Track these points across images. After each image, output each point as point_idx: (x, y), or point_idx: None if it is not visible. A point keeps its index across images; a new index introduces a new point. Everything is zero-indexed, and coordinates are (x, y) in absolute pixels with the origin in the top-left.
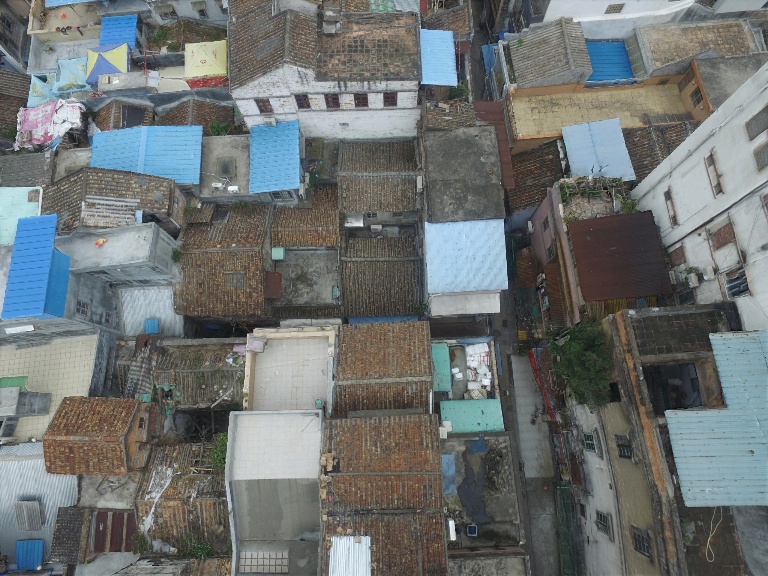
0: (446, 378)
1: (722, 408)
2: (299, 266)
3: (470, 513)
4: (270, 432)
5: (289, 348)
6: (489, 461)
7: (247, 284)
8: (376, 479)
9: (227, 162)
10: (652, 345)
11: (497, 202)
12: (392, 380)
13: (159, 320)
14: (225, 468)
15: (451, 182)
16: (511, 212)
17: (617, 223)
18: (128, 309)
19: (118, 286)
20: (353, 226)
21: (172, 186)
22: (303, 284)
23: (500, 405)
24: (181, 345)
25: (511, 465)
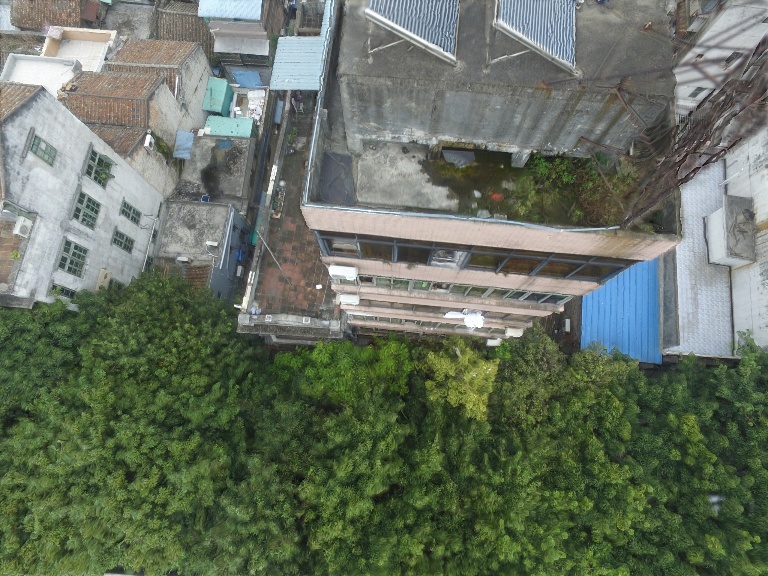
0: (219, 102)
1: (316, 36)
2: (127, 15)
3: (206, 187)
4: (38, 72)
5: (85, 47)
6: (230, 155)
7: (68, 5)
8: (100, 100)
9: None
10: None
11: None
12: (149, 65)
13: None
14: None
15: None
16: None
17: None
18: None
19: None
20: None
21: None
22: (126, 28)
23: (252, 122)
24: (2, 33)
25: (246, 159)
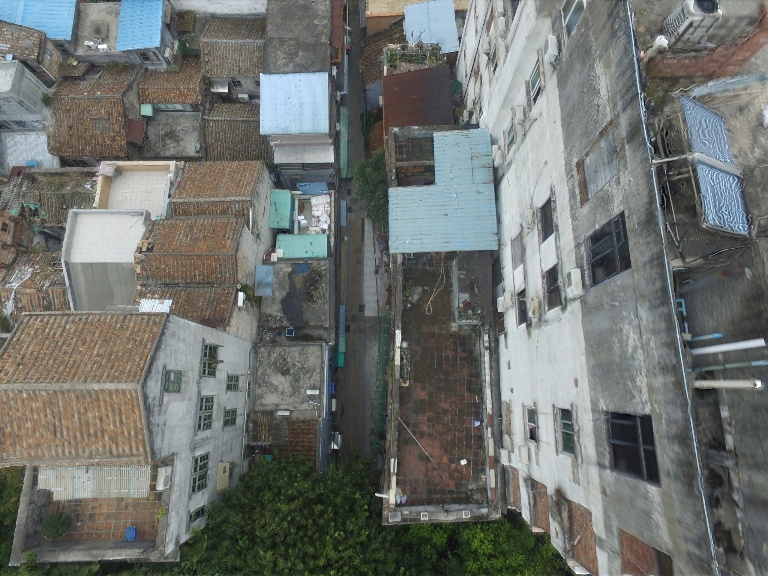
0: (285, 218)
1: (431, 185)
2: (169, 125)
3: (289, 319)
4: (104, 227)
5: (140, 178)
6: (310, 280)
7: (111, 129)
8: (181, 259)
9: (99, 24)
10: (415, 160)
11: (323, 58)
12: (218, 199)
13: (39, 162)
14: (62, 251)
15: (286, 40)
16: (363, 86)
17: (421, 76)
18: (11, 152)
19: (1, 130)
20: (218, 92)
21: (43, 38)
22: (171, 140)
23: (326, 238)
24: (46, 172)
25: (327, 283)
